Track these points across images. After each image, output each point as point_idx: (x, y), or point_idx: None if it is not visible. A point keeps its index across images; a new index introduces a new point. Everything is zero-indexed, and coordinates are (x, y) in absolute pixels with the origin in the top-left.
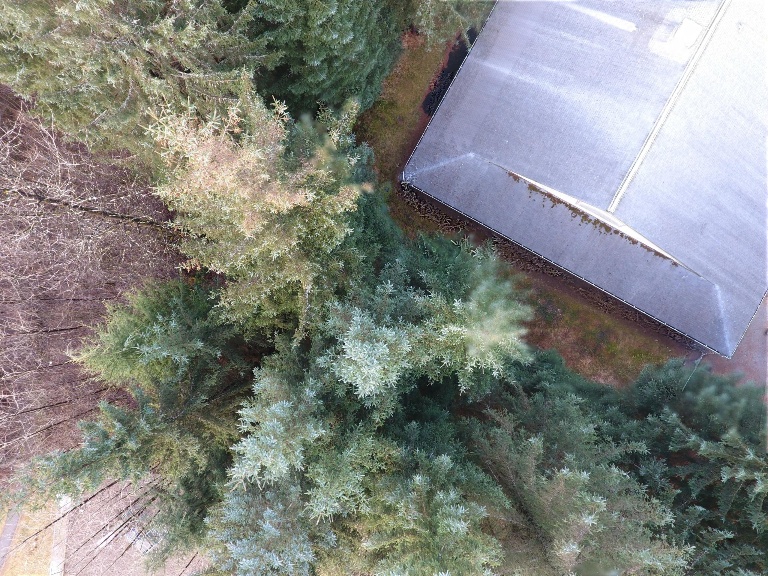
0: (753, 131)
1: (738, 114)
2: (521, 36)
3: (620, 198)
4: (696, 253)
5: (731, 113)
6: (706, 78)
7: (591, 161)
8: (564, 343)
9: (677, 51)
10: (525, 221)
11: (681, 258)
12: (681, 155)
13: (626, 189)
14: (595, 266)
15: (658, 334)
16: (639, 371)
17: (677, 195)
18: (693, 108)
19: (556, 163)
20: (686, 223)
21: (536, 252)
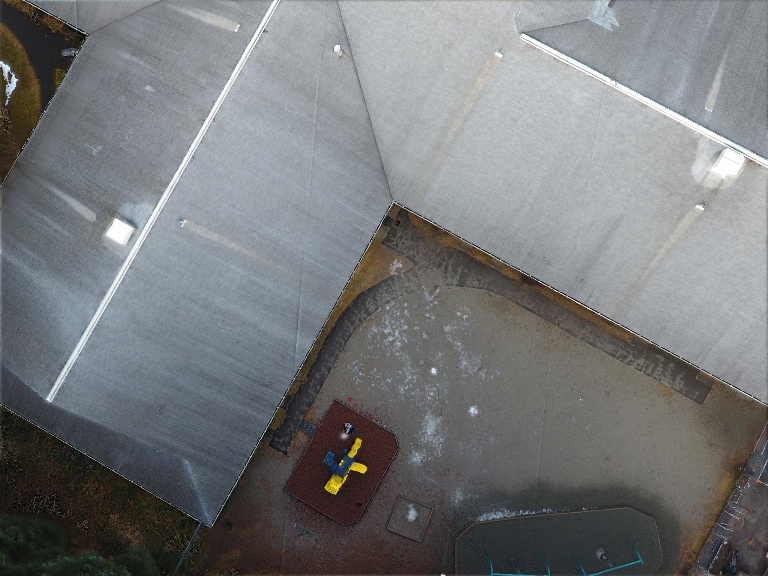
0: (210, 316)
1: (190, 301)
2: (15, 216)
3: (57, 389)
4: (156, 432)
5: (181, 301)
6: (147, 271)
7: (43, 349)
8: (96, 498)
9: (120, 246)
10: (18, 393)
11: (139, 438)
12: (126, 344)
13: (64, 379)
14: (83, 437)
15: None
16: (165, 526)
17: (126, 381)
18: (135, 300)
19: (18, 348)
20: (141, 405)
21: (32, 422)
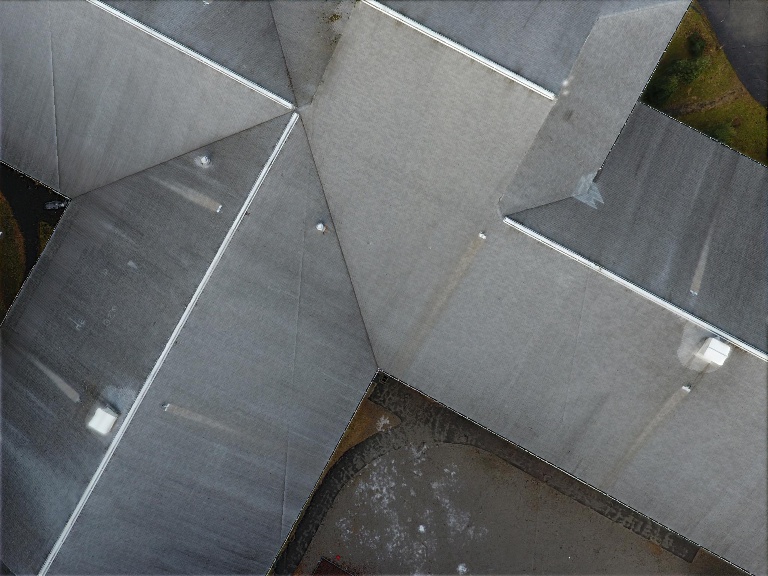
0: (195, 495)
1: (175, 483)
2: None
3: None
4: None
5: (166, 483)
6: (131, 457)
7: (27, 534)
8: None
9: None
10: (3, 566)
11: None
12: (110, 529)
13: (49, 569)
14: None
15: None
16: None
17: (111, 565)
18: (119, 486)
19: (2, 530)
20: None
21: None
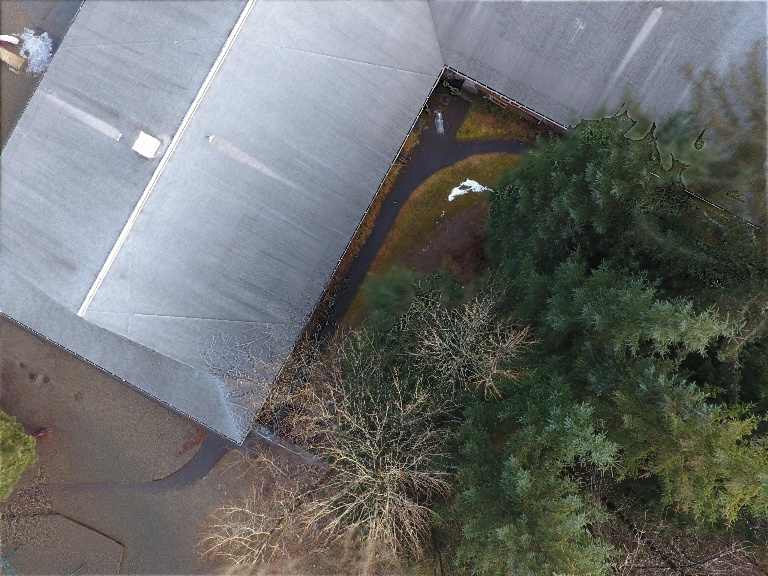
0: None
1: None
2: (642, 120)
3: None
4: None
5: None
6: None
7: None
8: None
9: None
10: None
11: None
12: None
13: None
14: None
15: None
16: None
17: None
18: None
19: None
20: None
21: None
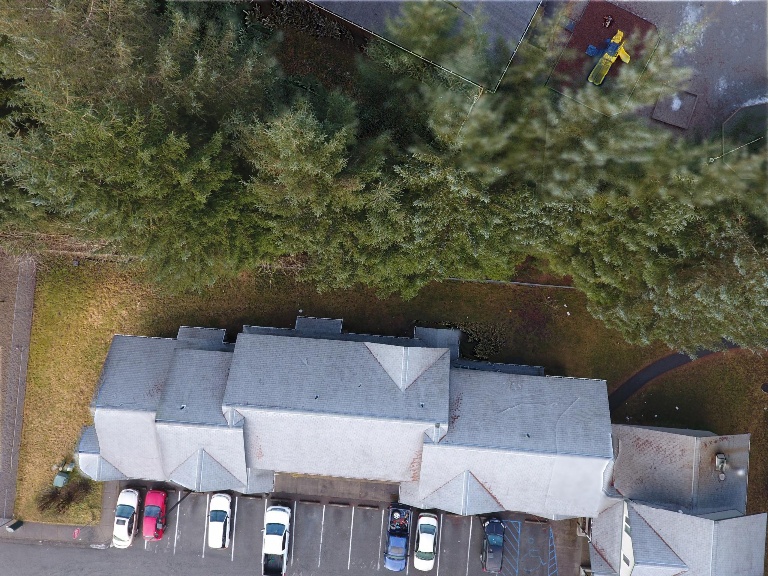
0: None
1: None
2: None
3: None
4: None
5: None
6: None
7: None
8: (354, 105)
9: None
10: None
11: None
12: None
13: None
14: (362, 8)
15: (440, 89)
16: (425, 128)
17: None
18: None
19: None
20: None
21: None
